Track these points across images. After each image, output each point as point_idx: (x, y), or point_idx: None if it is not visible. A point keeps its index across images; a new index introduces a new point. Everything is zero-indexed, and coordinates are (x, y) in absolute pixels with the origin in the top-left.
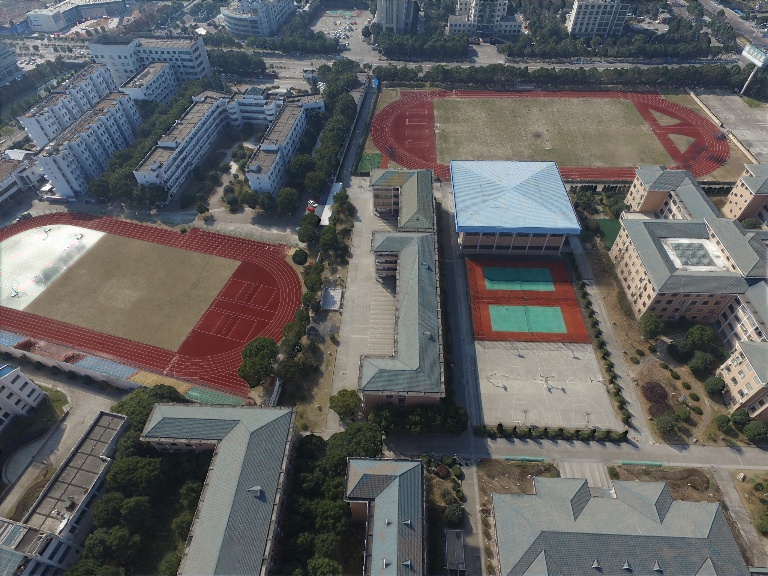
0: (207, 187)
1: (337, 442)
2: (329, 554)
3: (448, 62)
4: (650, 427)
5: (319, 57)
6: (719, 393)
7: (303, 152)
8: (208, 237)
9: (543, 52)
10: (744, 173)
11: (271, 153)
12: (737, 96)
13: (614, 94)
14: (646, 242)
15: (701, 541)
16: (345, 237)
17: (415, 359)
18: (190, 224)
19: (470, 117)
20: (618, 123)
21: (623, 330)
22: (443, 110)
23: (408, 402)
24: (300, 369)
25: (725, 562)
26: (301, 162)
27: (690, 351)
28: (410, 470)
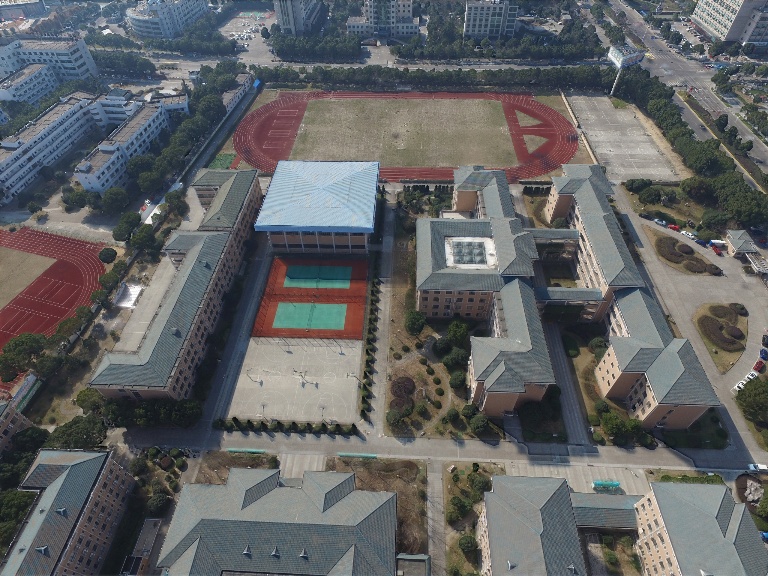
0: (51, 187)
1: (54, 434)
2: (1, 541)
3: (338, 63)
4: (385, 421)
5: (215, 58)
6: (464, 388)
7: (153, 152)
8: (34, 236)
9: (431, 53)
10: (563, 173)
11: (108, 153)
12: (607, 97)
13: (487, 95)
14: (426, 241)
15: (349, 529)
16: (167, 236)
17: (149, 354)
18: (22, 223)
19: (337, 118)
20: (479, 124)
21: (398, 327)
22: (314, 111)
23: (143, 396)
24: (70, 364)
25: (368, 549)
26: (136, 162)
27: (448, 347)
28: (89, 460)
